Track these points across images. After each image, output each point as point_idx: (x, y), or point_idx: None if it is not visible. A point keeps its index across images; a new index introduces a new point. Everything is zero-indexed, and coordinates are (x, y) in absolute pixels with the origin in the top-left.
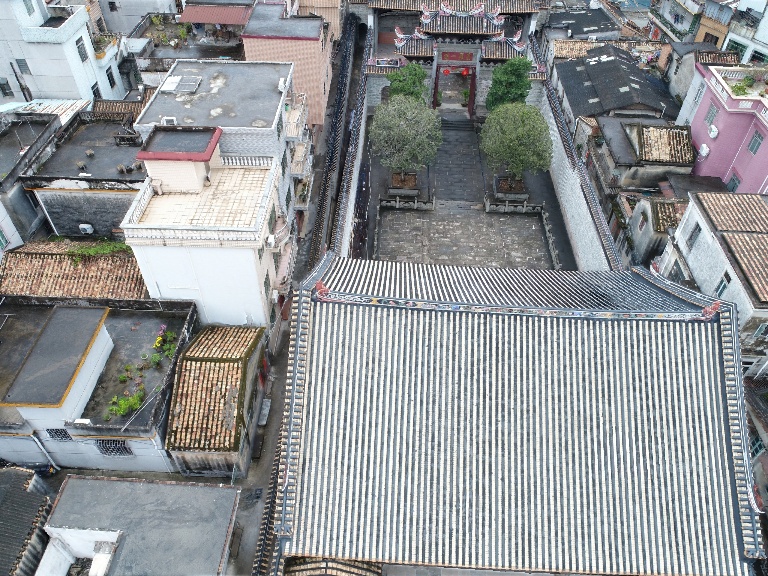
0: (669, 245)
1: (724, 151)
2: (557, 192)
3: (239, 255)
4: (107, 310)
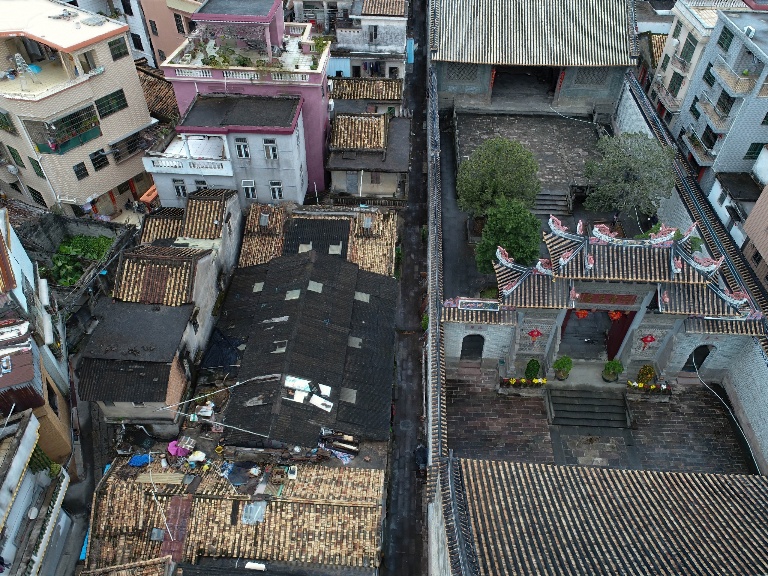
0: None
1: None
2: None
3: None
4: None
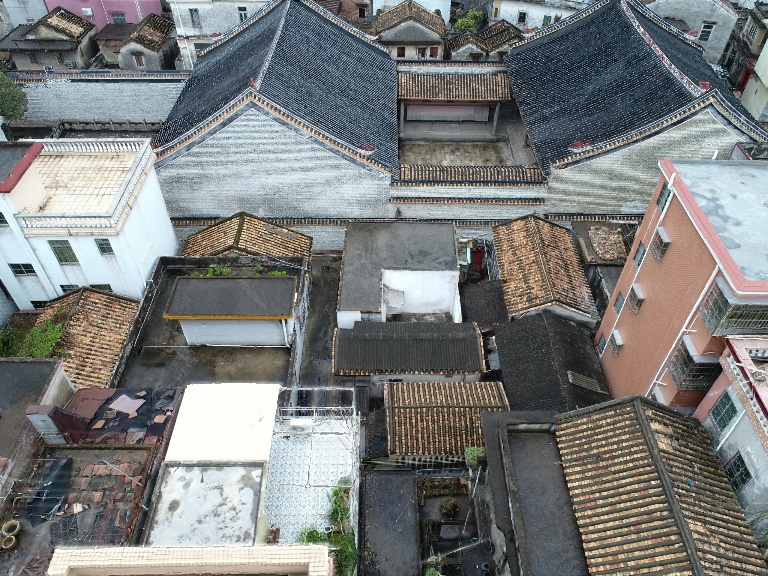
0: (180, 43)
1: (95, 5)
2: (34, 124)
3: (151, 179)
4: (182, 276)
